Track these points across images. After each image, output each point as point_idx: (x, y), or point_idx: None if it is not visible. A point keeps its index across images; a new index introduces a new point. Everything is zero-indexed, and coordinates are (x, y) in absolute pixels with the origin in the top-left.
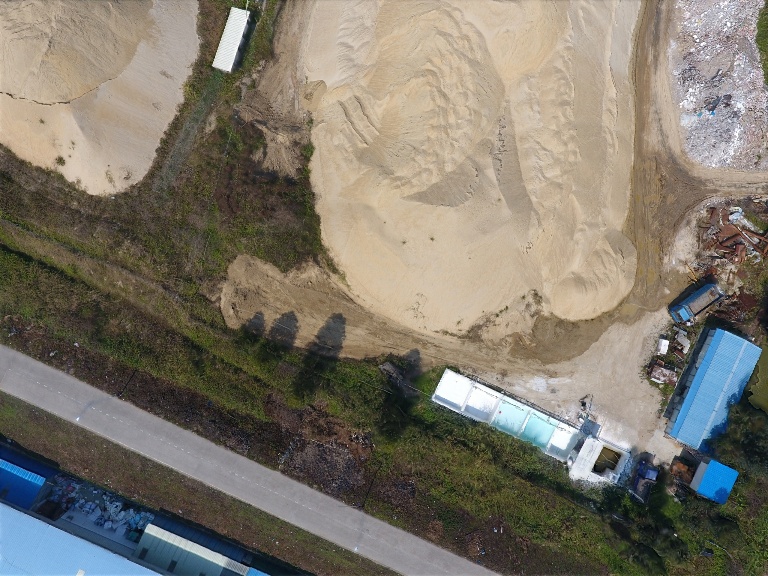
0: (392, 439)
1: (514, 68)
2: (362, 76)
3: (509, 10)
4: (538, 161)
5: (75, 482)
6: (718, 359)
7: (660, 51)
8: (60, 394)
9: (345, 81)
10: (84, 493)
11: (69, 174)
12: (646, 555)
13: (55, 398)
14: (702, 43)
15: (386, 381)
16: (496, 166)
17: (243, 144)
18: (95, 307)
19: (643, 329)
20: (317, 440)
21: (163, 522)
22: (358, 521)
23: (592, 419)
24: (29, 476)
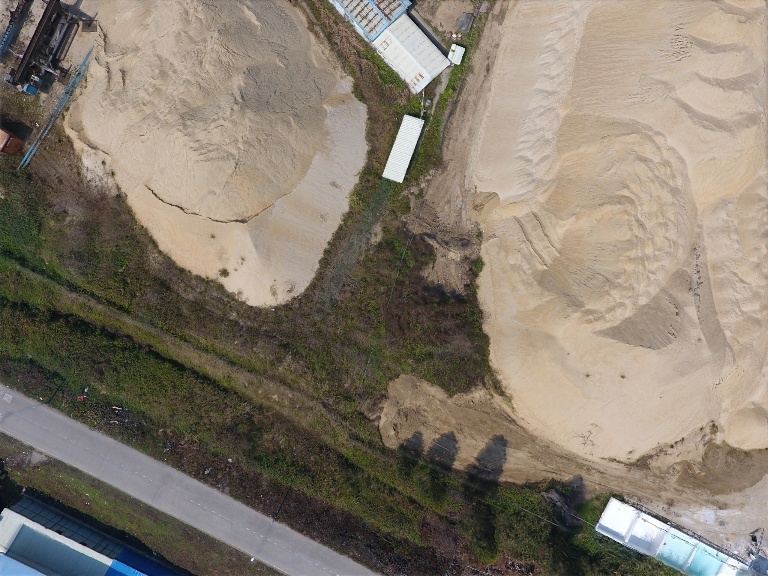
0: None
1: (712, 193)
2: (541, 192)
3: (720, 138)
4: (735, 294)
5: None
6: None
7: None
8: (214, 513)
9: (523, 197)
10: None
11: (231, 285)
12: None
13: (209, 517)
14: None
15: (552, 511)
16: (697, 303)
17: (415, 261)
18: (248, 420)
19: None
20: (472, 566)
21: None
22: None
23: (762, 555)
24: None
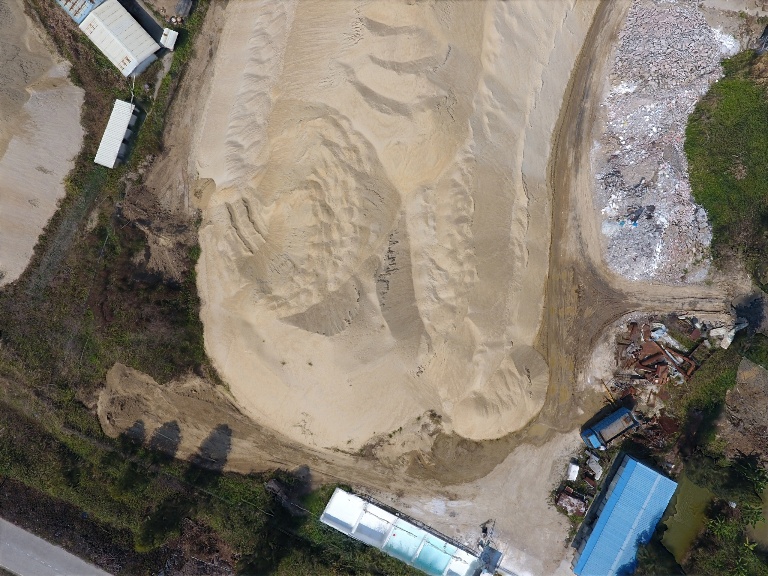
0: None
1: (410, 179)
2: (251, 178)
3: (399, 122)
4: (431, 281)
5: None
6: (628, 493)
7: (582, 152)
8: None
9: (233, 183)
10: None
11: None
12: None
13: None
14: (628, 146)
15: (268, 502)
16: (381, 289)
17: (121, 248)
18: None
19: (553, 451)
20: (197, 557)
21: None
22: None
23: (493, 546)
24: None
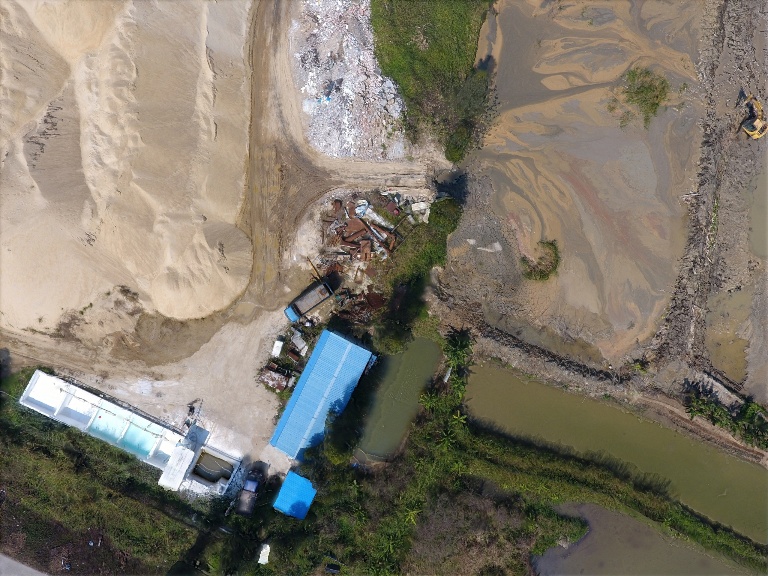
0: None
1: (72, 45)
2: None
3: None
4: (95, 146)
5: None
6: (322, 362)
7: (281, 32)
8: None
9: None
10: None
11: None
12: None
13: None
14: (324, 24)
15: None
16: (31, 150)
17: None
18: None
19: (260, 329)
20: None
21: None
22: None
23: (200, 425)
24: None
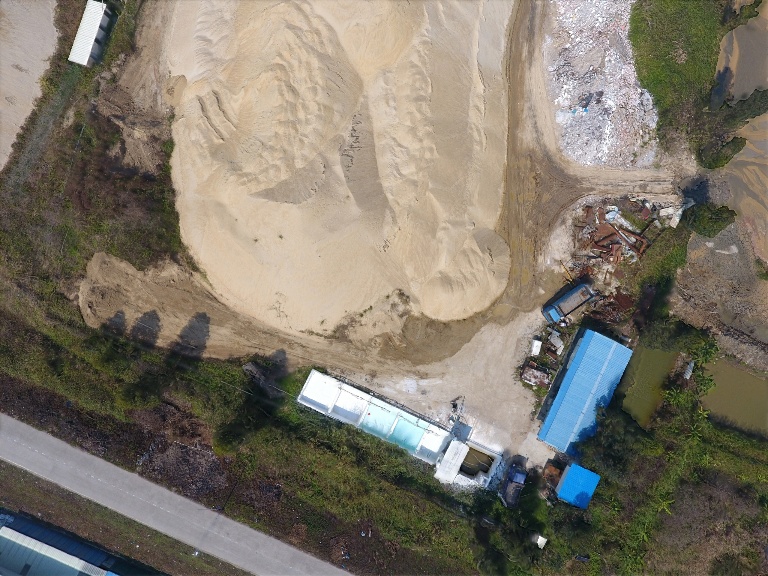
0: (226, 441)
1: (370, 63)
2: (220, 70)
3: (356, 3)
4: (394, 158)
5: None
6: (587, 360)
7: (535, 47)
8: None
9: (203, 75)
10: None
11: None
12: (489, 561)
13: None
14: (577, 39)
15: (247, 382)
16: (345, 162)
17: (97, 139)
18: None
19: (517, 330)
20: (180, 442)
21: (22, 525)
22: (218, 524)
23: (463, 421)
24: None
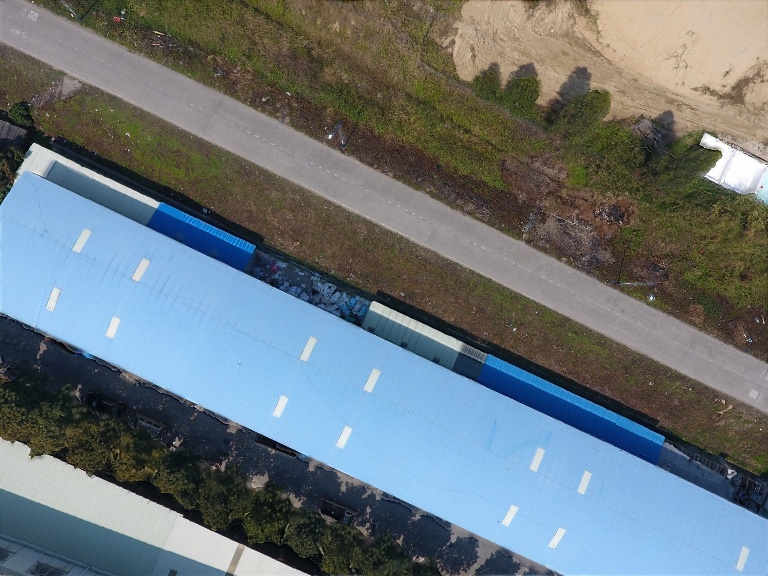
0: None
1: None
2: None
3: None
4: None
5: (280, 260)
6: None
7: None
8: (274, 146)
9: None
10: (288, 276)
11: None
12: None
13: (268, 150)
14: None
15: (645, 139)
16: None
17: None
18: (307, 53)
19: None
20: (557, 214)
21: None
22: (612, 301)
23: None
24: (237, 242)
